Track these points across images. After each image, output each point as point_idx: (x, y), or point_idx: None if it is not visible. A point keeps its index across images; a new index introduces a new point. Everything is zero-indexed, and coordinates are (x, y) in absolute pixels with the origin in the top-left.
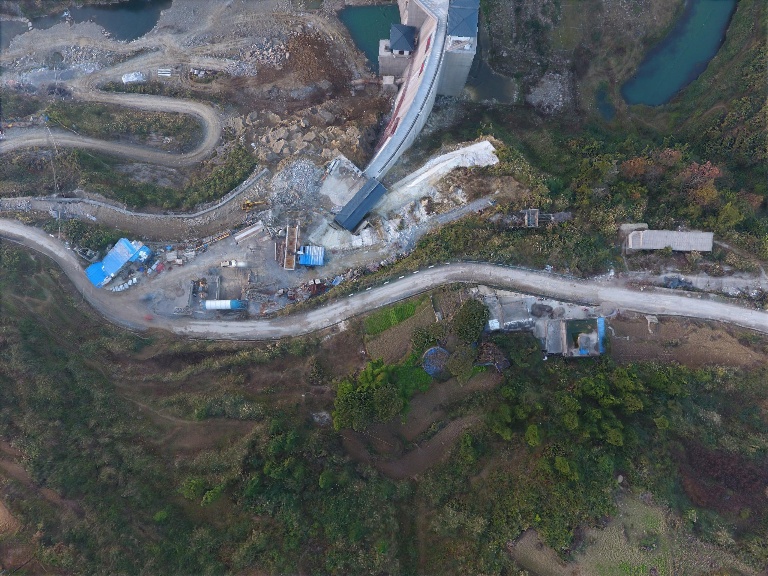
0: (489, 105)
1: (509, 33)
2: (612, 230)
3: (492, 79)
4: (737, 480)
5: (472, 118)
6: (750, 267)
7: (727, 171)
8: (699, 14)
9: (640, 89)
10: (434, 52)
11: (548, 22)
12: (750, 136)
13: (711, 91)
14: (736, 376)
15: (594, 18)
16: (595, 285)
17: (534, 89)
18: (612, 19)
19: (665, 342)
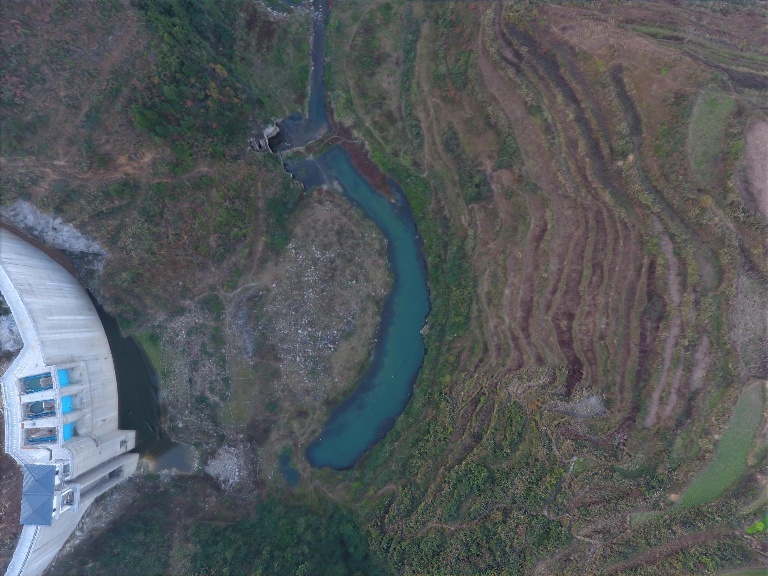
0: (161, 484)
1: (185, 402)
2: None
3: (172, 446)
4: None
5: (140, 503)
6: None
7: None
8: (388, 366)
9: (327, 449)
10: None
11: (216, 400)
12: (403, 543)
13: (388, 463)
14: None
15: (269, 388)
16: None
17: (211, 461)
18: (290, 385)
19: None
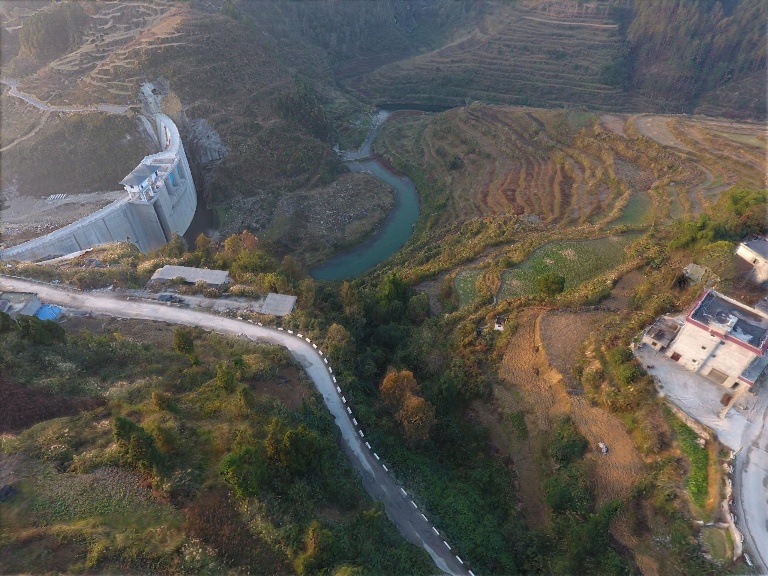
0: None
1: None
2: (141, 267)
3: None
4: (5, 409)
5: None
6: (245, 291)
7: (266, 241)
8: (385, 239)
9: (327, 272)
10: (120, 202)
11: (257, 226)
12: None
13: None
14: (147, 351)
15: (296, 230)
16: (88, 295)
17: None
18: (311, 232)
19: (104, 328)
